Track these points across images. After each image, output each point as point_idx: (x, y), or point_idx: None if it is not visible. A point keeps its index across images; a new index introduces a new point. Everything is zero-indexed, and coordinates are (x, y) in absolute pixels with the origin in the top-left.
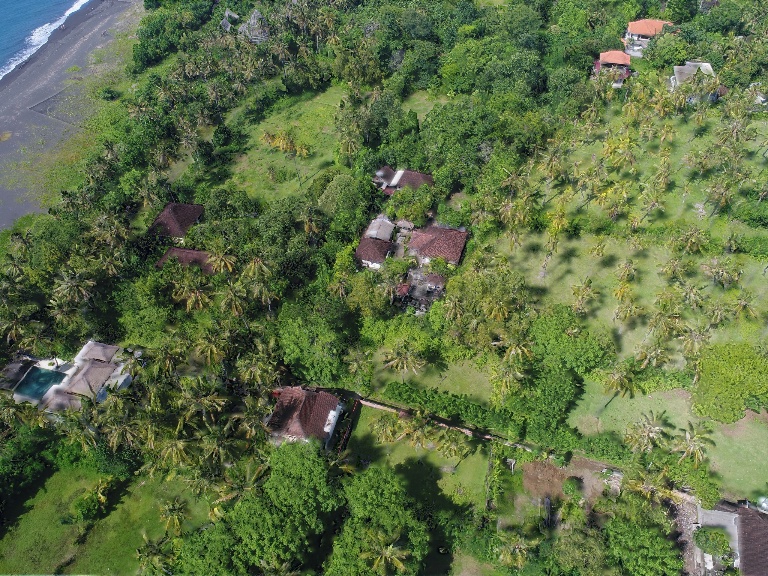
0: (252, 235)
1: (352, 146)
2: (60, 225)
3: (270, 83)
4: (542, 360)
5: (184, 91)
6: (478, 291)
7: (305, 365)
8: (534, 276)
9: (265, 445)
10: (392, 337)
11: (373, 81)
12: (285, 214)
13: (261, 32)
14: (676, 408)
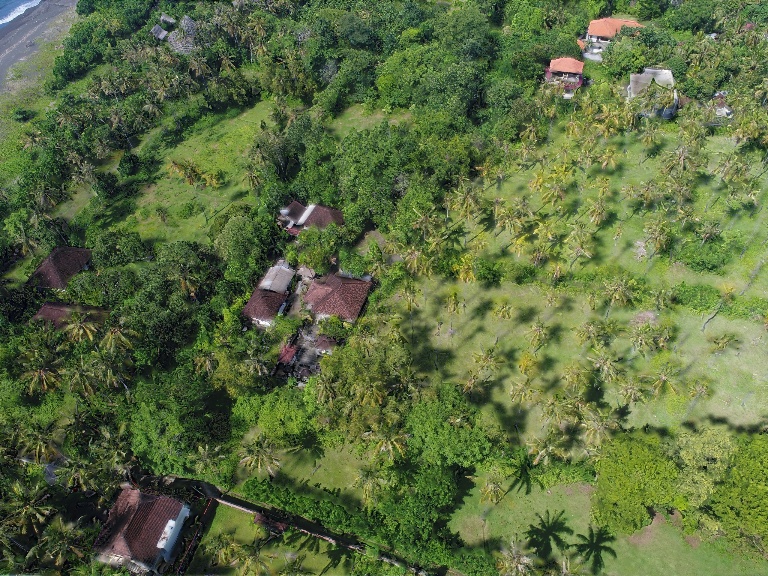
0: (136, 287)
1: (254, 181)
2: None
3: (196, 98)
4: (421, 454)
5: (90, 114)
6: (350, 372)
7: (152, 459)
8: (441, 335)
9: (78, 572)
10: (267, 415)
11: (304, 95)
12: (171, 263)
13: (185, 43)
14: (577, 507)
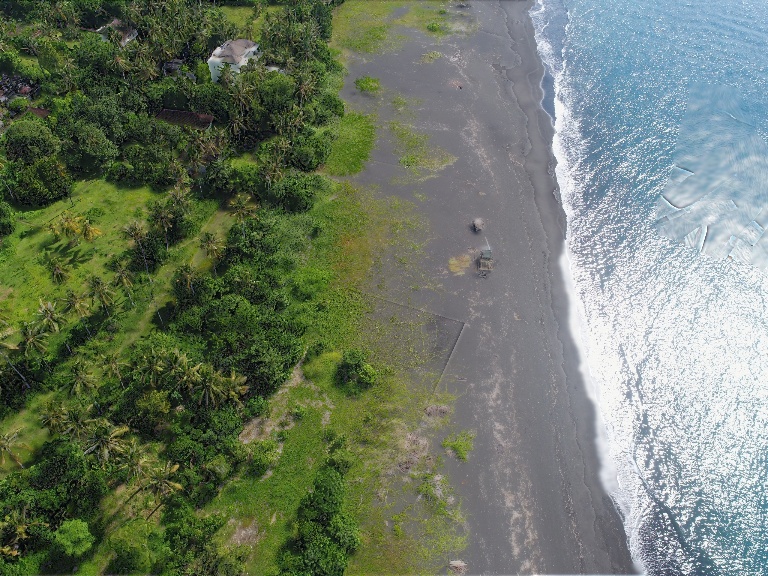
0: None
1: None
2: (272, 87)
3: None
4: None
5: None
6: None
7: None
8: None
9: None
10: None
11: None
12: None
13: None
14: None
